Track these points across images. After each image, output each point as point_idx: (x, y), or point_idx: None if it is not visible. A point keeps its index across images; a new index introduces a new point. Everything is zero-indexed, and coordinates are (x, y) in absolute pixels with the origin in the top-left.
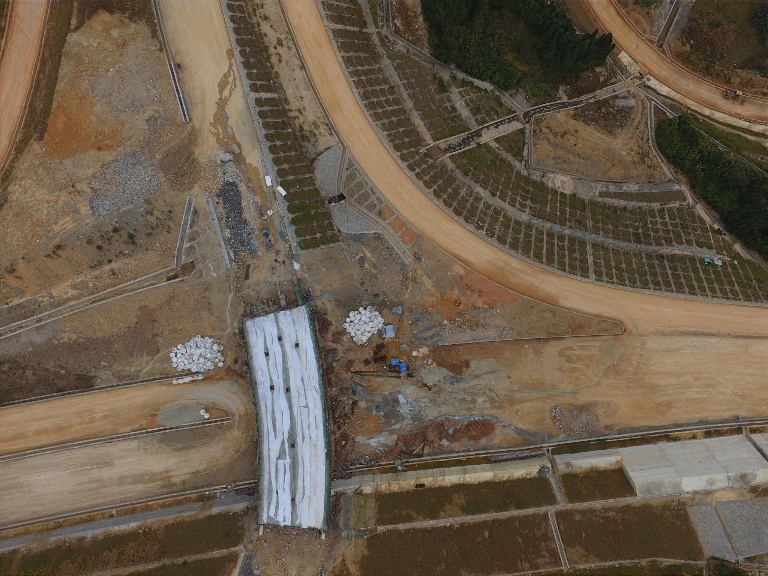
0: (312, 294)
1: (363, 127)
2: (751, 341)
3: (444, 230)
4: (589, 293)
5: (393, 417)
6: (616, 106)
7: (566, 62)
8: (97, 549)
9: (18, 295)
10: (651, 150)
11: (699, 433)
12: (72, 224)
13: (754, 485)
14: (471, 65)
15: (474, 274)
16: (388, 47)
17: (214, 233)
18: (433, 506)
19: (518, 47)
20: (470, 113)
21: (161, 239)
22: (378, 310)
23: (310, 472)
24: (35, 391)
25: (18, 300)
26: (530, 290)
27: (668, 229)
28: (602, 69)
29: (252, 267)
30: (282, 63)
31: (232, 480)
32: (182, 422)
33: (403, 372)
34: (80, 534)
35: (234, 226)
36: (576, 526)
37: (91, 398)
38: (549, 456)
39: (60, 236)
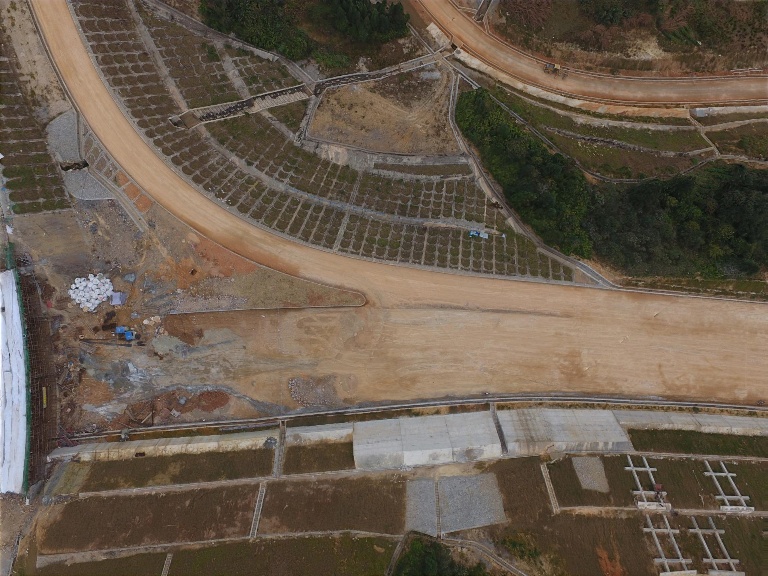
0: (30, 259)
1: (99, 92)
2: (502, 315)
3: (181, 197)
4: (331, 263)
5: (122, 386)
6: (420, 79)
7: (360, 32)
8: None
9: None
10: (448, 123)
11: (443, 408)
12: None
13: (480, 461)
14: (251, 34)
15: (209, 242)
16: (146, 13)
17: None
18: (145, 474)
19: (310, 17)
20: (243, 82)
21: None
22: (111, 278)
23: (11, 437)
24: None
25: None
26: (269, 259)
27: (440, 202)
28: (405, 41)
29: None
30: (15, 27)
31: None
32: None
33: (133, 340)
34: None
35: None
36: (282, 497)
37: None
38: (284, 428)
39: None
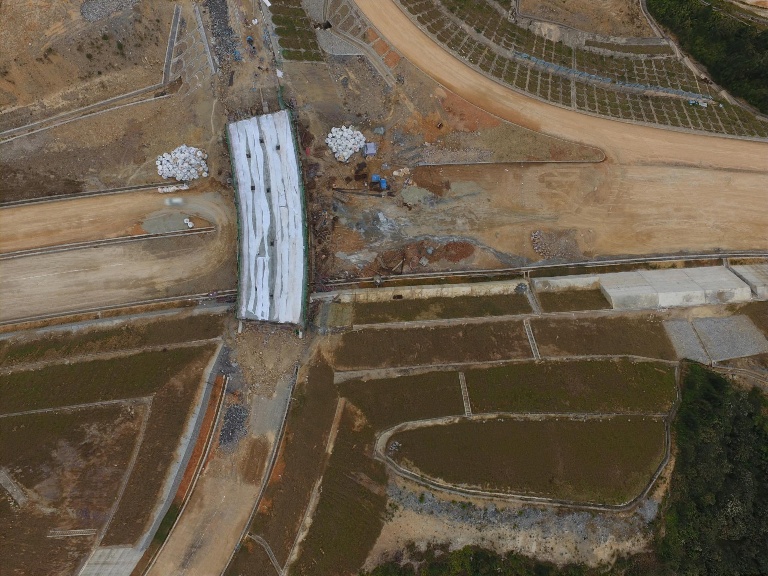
0: (295, 104)
1: None
2: (733, 174)
3: (427, 55)
4: (571, 121)
5: (373, 235)
6: None
7: None
8: (81, 341)
9: (11, 103)
10: (641, 12)
11: (679, 262)
12: (63, 29)
13: (731, 303)
14: None
15: (456, 97)
16: None
17: (200, 41)
18: (409, 312)
19: None
20: None
21: (149, 52)
22: (360, 131)
23: (288, 269)
24: (25, 194)
25: (11, 108)
26: (511, 116)
27: (654, 75)
28: None
29: (236, 74)
30: None
31: (214, 289)
32: (166, 229)
33: (384, 191)
34: (65, 329)
35: (219, 33)
36: (550, 331)
37: (79, 204)
38: (527, 279)
39: (51, 40)
